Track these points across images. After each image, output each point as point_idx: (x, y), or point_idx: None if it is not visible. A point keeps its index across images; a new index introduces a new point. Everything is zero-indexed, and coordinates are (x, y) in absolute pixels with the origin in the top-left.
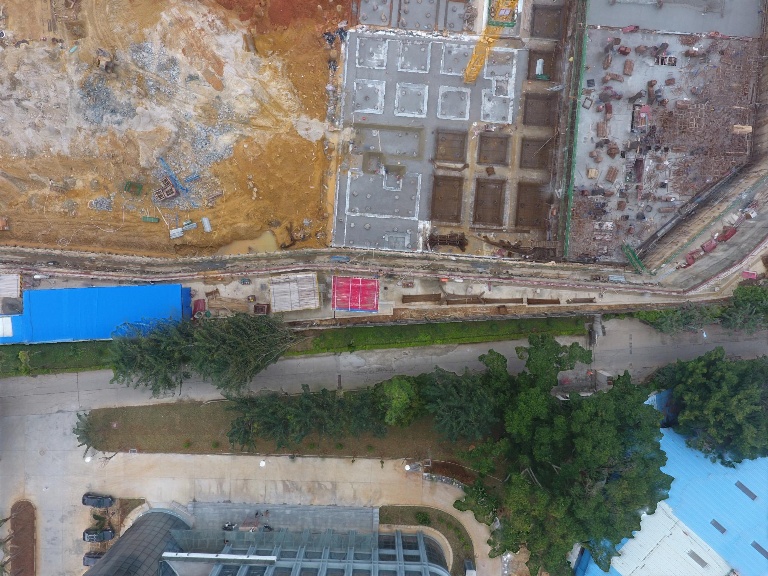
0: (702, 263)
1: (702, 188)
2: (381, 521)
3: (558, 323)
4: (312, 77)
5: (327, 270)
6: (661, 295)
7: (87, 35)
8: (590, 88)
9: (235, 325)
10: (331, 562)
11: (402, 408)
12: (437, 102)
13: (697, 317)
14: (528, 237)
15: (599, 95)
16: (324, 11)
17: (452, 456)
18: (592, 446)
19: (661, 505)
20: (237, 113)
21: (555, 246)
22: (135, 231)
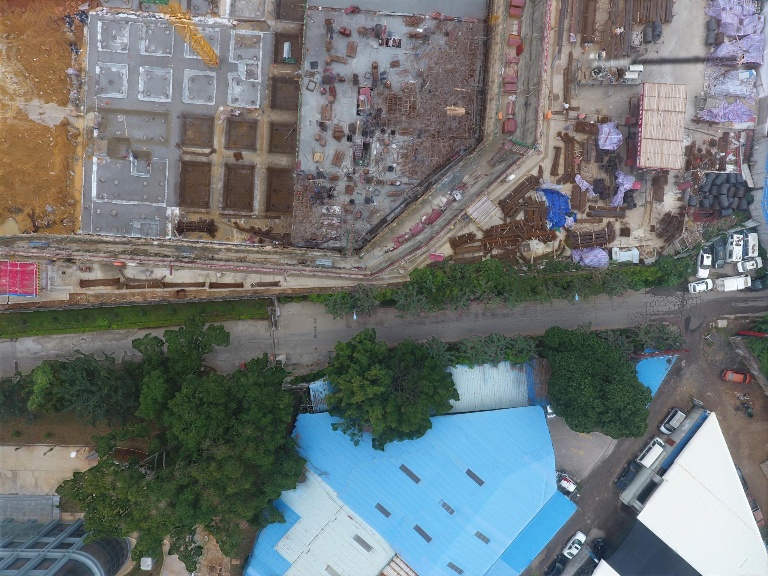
0: (404, 246)
1: (431, 172)
2: (64, 509)
3: (239, 307)
4: (45, 60)
5: (0, 254)
6: (347, 278)
7: None
8: (313, 70)
9: None
10: None
11: (41, 393)
12: (182, 86)
13: (362, 299)
14: (279, 223)
15: (322, 77)
16: None
17: (134, 443)
18: (183, 428)
19: (326, 490)
20: None
21: None
22: None
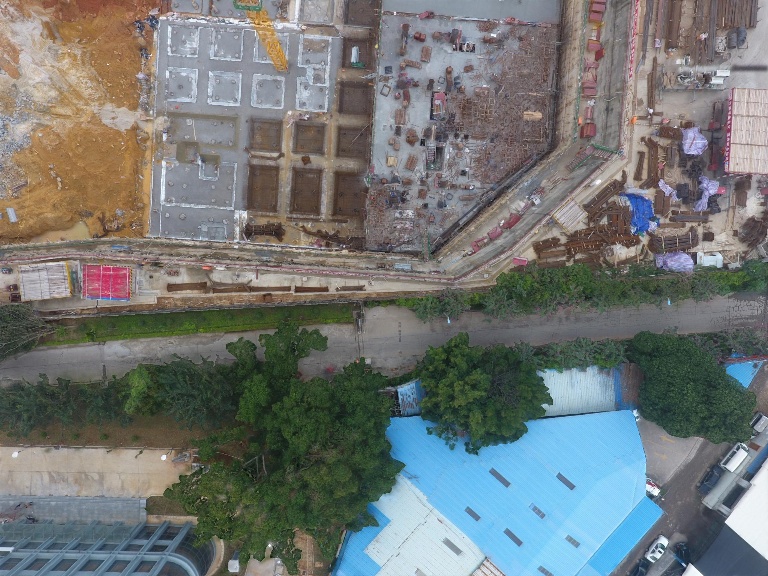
0: (484, 250)
1: (503, 176)
2: (150, 512)
3: (325, 311)
4: (118, 65)
5: (89, 259)
6: (432, 282)
7: None
8: (388, 75)
9: None
10: (68, 553)
11: (139, 397)
12: (251, 90)
13: (452, 304)
14: (346, 227)
15: (397, 82)
16: None
17: None
18: (293, 432)
19: (416, 493)
20: (35, 101)
21: (365, 235)
22: None
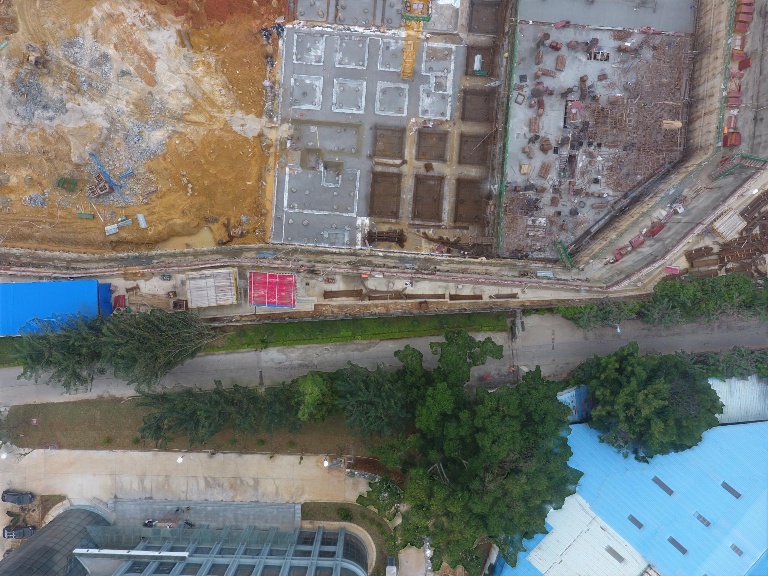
0: (629, 259)
1: (635, 184)
2: (303, 517)
3: (480, 319)
4: (247, 73)
5: (248, 266)
6: (584, 290)
7: (18, 30)
8: (522, 83)
9: (146, 321)
10: (243, 558)
11: (314, 404)
12: (375, 98)
13: (615, 312)
14: (467, 233)
15: (531, 90)
16: (261, 6)
17: None
18: (492, 441)
19: (578, 500)
20: (170, 109)
21: (491, 242)
22: (71, 227)
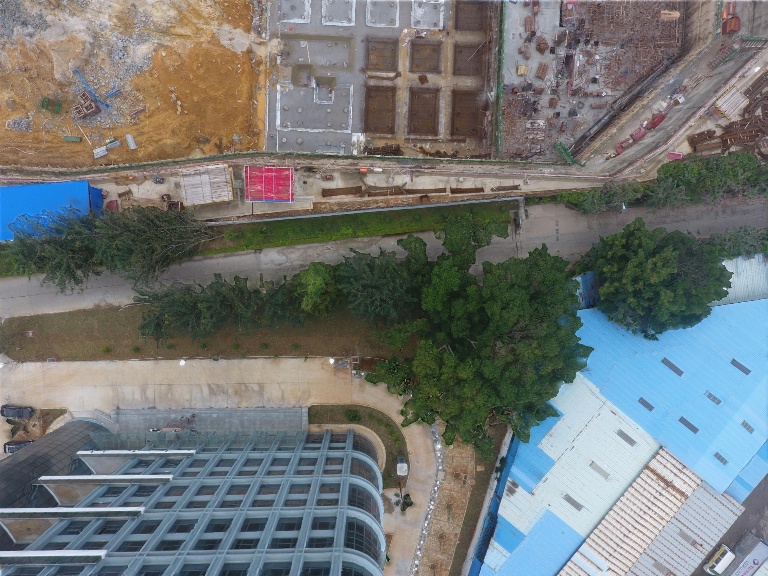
0: (630, 150)
1: (634, 82)
2: (311, 421)
3: (482, 211)
4: None
5: (243, 165)
6: (587, 180)
7: None
8: None
9: (141, 214)
10: (252, 453)
11: (317, 293)
12: (365, 9)
13: (619, 194)
14: (465, 146)
15: None
16: None
17: (380, 352)
18: (501, 308)
19: (588, 386)
20: (154, 22)
21: (490, 151)
22: (58, 152)
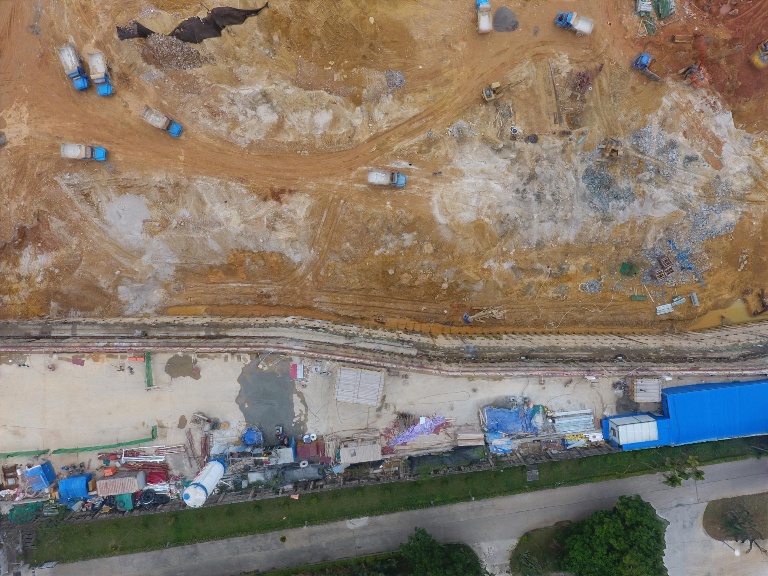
0: None
1: None
2: None
3: None
4: None
5: None
6: None
7: (588, 124)
8: None
9: None
10: None
11: None
12: None
13: None
14: None
15: None
16: None
17: None
18: None
19: None
20: (733, 190)
21: None
22: (620, 309)
